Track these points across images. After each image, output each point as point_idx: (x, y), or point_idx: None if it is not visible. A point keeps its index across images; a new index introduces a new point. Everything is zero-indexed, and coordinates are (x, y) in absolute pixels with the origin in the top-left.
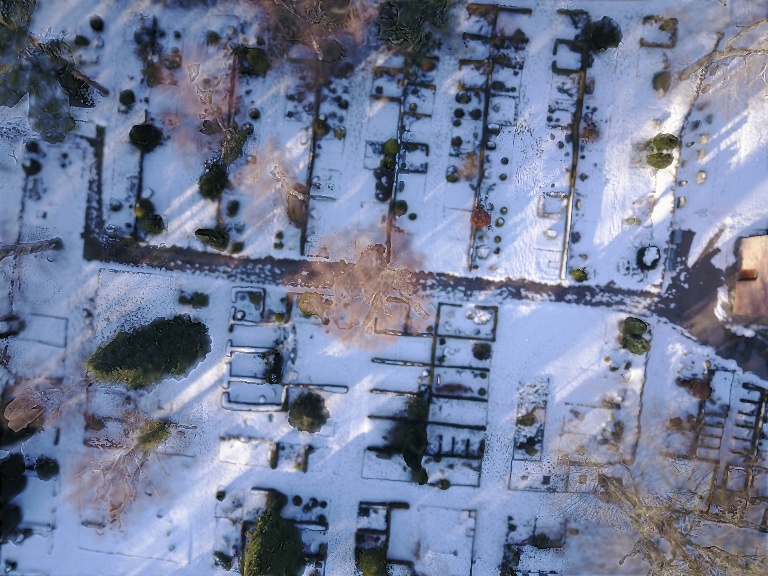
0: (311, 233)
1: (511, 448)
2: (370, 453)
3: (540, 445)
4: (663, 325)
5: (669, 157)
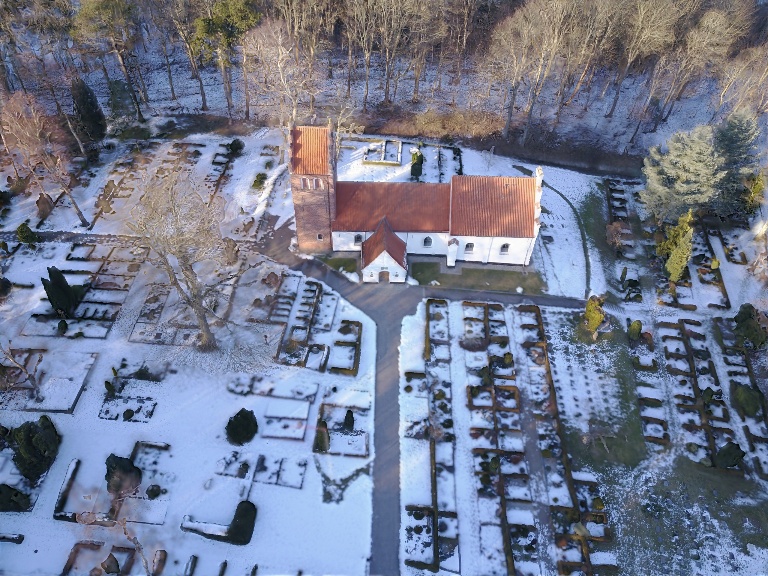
0: (48, 220)
1: (137, 316)
2: (32, 319)
3: (159, 315)
4: (256, 255)
5: (261, 181)
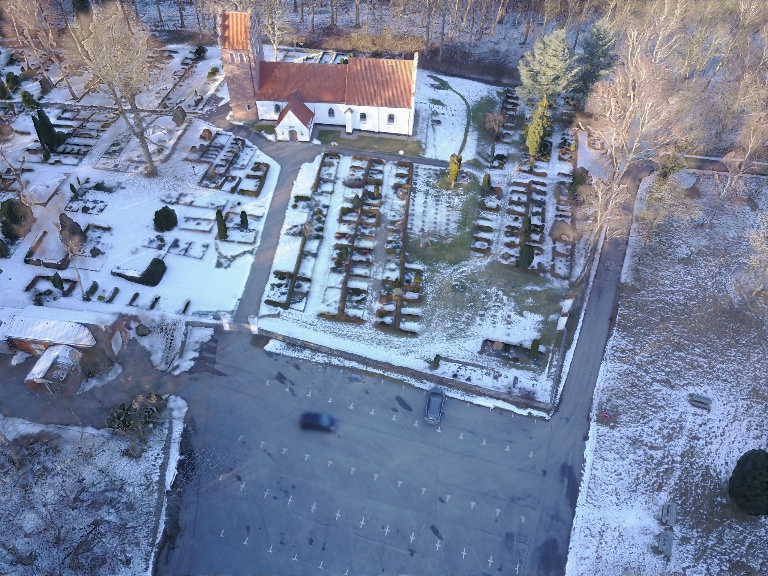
0: (48, 96)
1: (102, 154)
2: (26, 152)
3: (119, 154)
4: (200, 121)
5: (213, 72)
